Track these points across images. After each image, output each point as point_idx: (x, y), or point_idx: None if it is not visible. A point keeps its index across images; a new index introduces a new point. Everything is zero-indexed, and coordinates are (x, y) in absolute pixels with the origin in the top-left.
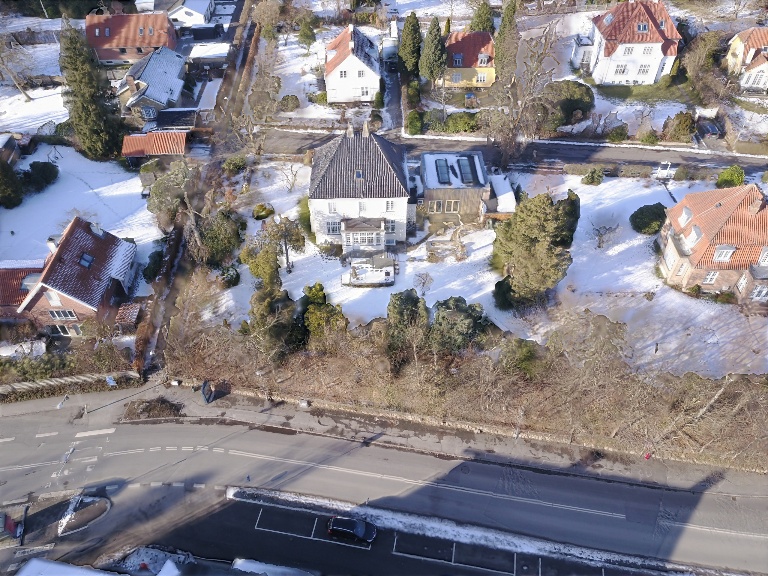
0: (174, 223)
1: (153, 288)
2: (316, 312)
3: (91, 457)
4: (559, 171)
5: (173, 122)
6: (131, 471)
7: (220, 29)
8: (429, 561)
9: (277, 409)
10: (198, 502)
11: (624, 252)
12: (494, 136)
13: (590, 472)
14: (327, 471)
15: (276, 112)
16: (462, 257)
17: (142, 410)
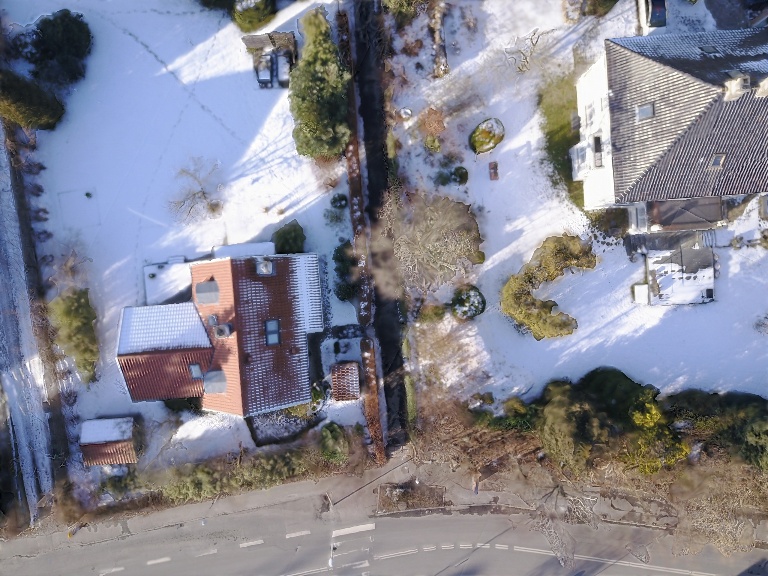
0: (349, 178)
1: None
2: (656, 459)
3: (361, 562)
4: None
5: None
6: None
7: None
8: None
9: None
10: None
11: None
12: None
13: None
14: (629, 568)
15: None
16: None
17: (398, 499)
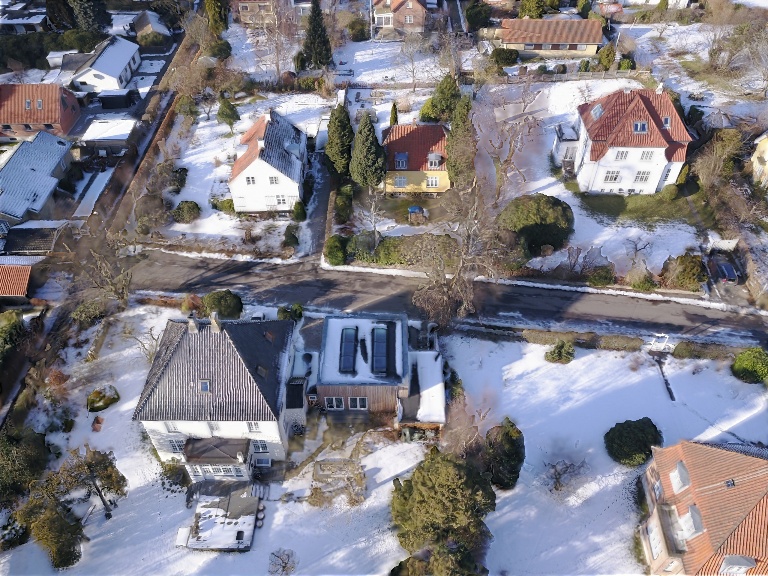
0: None
1: None
2: None
3: None
4: (517, 336)
5: (25, 244)
6: None
7: (135, 96)
8: None
9: None
10: None
11: (592, 501)
12: (420, 304)
13: None
14: None
15: (168, 224)
16: (357, 499)
17: None
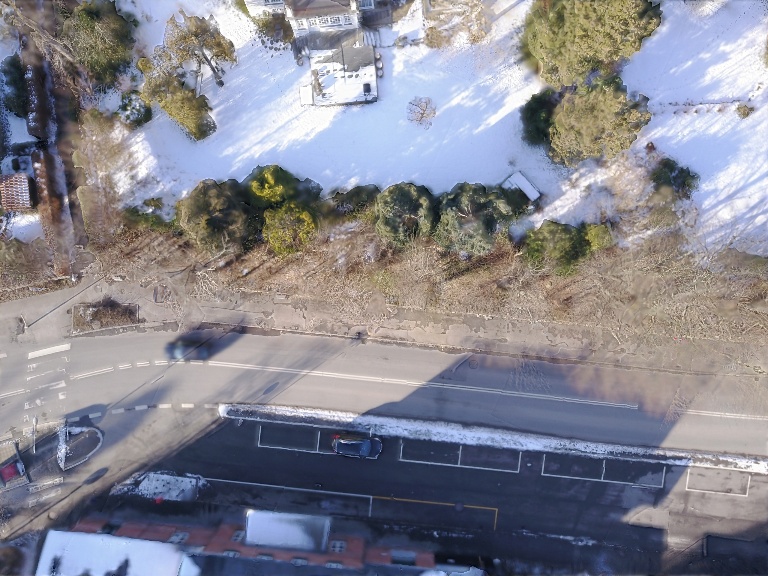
0: None
1: (31, 134)
2: (277, 229)
3: (58, 383)
4: None
5: None
6: (108, 395)
7: None
8: (436, 465)
9: (251, 303)
10: (192, 424)
11: (728, 8)
12: None
13: (610, 359)
14: (322, 378)
15: None
16: (478, 35)
17: (91, 318)
